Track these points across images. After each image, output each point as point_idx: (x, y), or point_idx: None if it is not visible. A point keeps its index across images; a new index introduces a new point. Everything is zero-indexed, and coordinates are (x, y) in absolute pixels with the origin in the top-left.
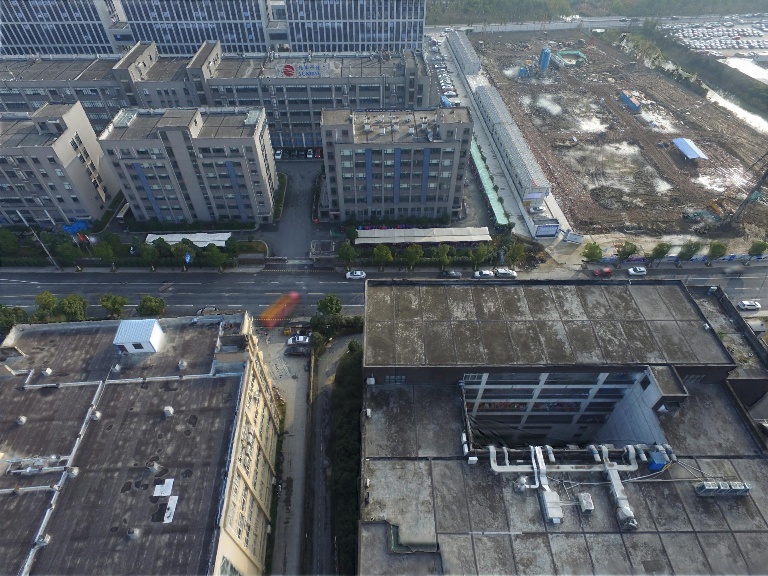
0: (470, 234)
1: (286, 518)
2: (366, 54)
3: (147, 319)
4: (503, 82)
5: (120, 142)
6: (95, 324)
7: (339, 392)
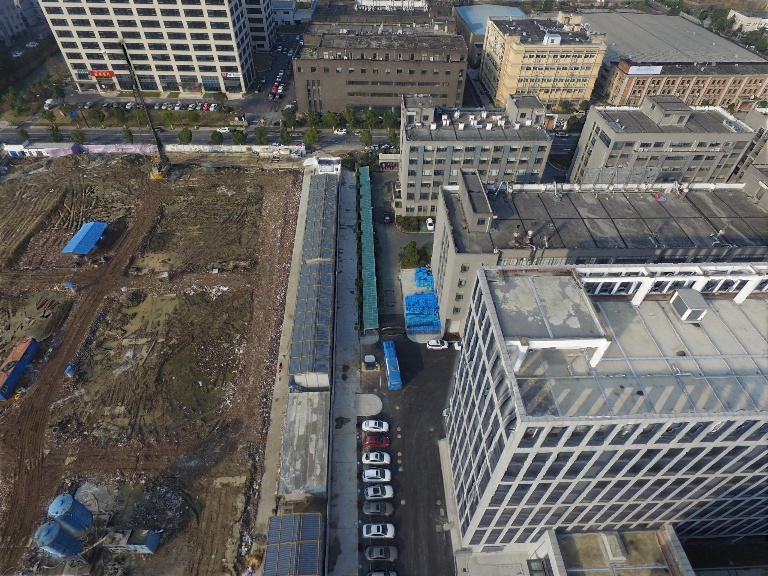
0: (395, 159)
1: (480, 89)
2: (561, 252)
3: (552, 36)
4: (225, 491)
5: (701, 107)
6: (576, 47)
7: (471, 95)
